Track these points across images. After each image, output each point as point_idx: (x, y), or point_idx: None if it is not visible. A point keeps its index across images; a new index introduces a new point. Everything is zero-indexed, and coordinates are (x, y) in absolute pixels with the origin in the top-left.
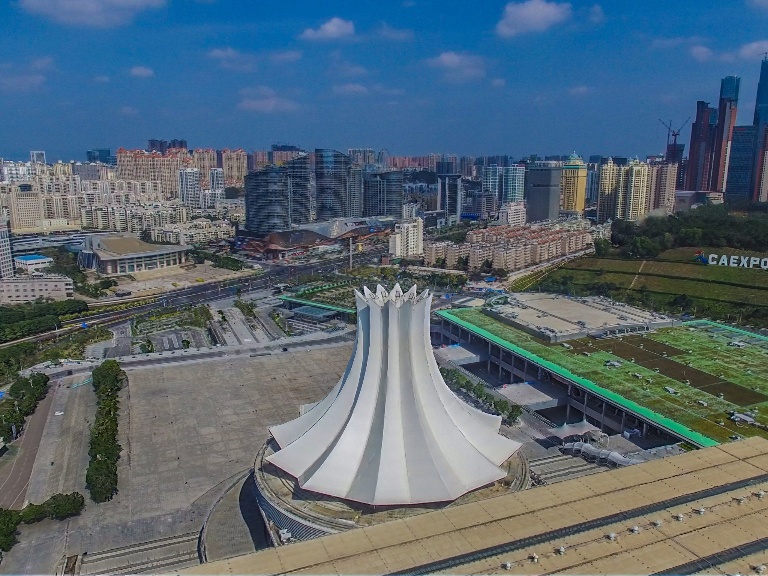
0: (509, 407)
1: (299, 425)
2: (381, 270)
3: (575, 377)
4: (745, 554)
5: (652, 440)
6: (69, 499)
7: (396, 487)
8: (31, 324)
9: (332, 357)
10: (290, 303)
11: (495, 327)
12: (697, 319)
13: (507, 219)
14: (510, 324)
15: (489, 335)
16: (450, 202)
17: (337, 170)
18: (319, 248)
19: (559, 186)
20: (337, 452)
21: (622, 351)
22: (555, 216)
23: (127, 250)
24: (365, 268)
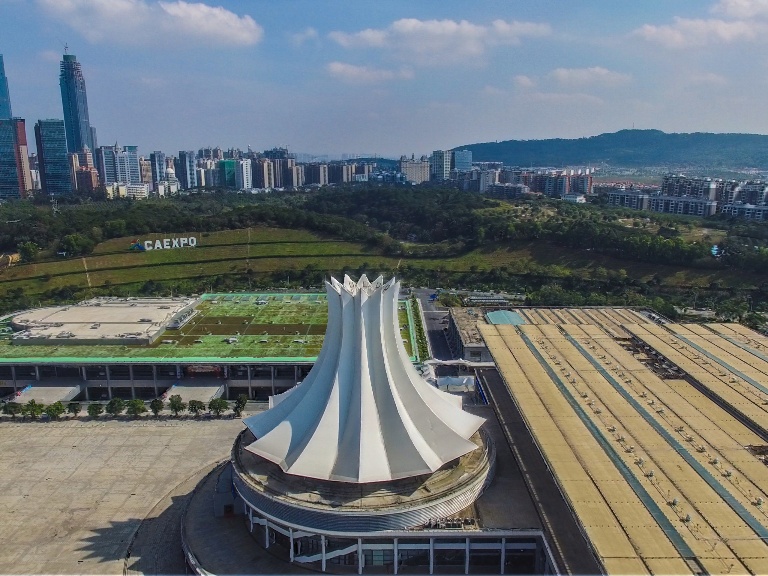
0: None
1: (317, 450)
2: None
3: (231, 359)
4: None
5: None
6: None
7: None
8: None
9: None
10: None
11: (67, 351)
12: None
13: None
14: (75, 344)
15: (79, 359)
16: None
17: None
18: None
19: None
20: None
21: (215, 330)
22: None
23: None
24: None
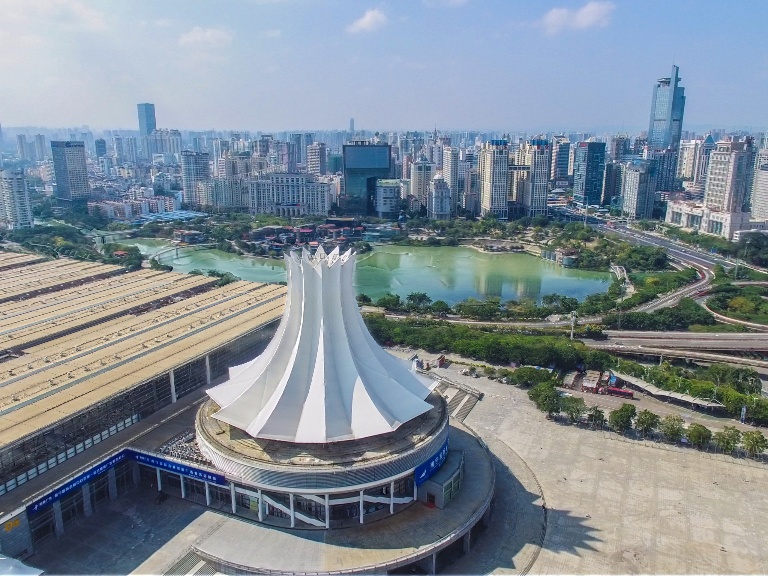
0: None
1: None
2: None
3: None
4: (33, 372)
5: None
6: None
7: None
8: None
9: None
10: None
11: None
12: None
13: None
14: None
15: None
16: None
17: None
18: None
19: None
20: None
21: None
22: None
23: None
24: None
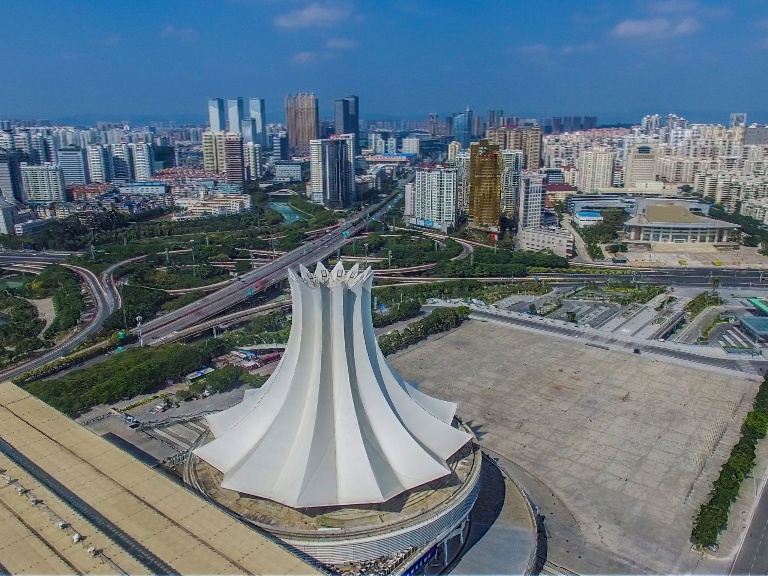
0: (759, 533)
1: None
2: None
3: None
4: None
5: None
6: None
7: (228, 453)
8: (500, 267)
9: (663, 376)
10: (760, 309)
11: None
12: None
13: None
14: None
15: None
16: None
17: None
18: None
19: None
20: (245, 404)
21: None
22: None
23: None
24: None
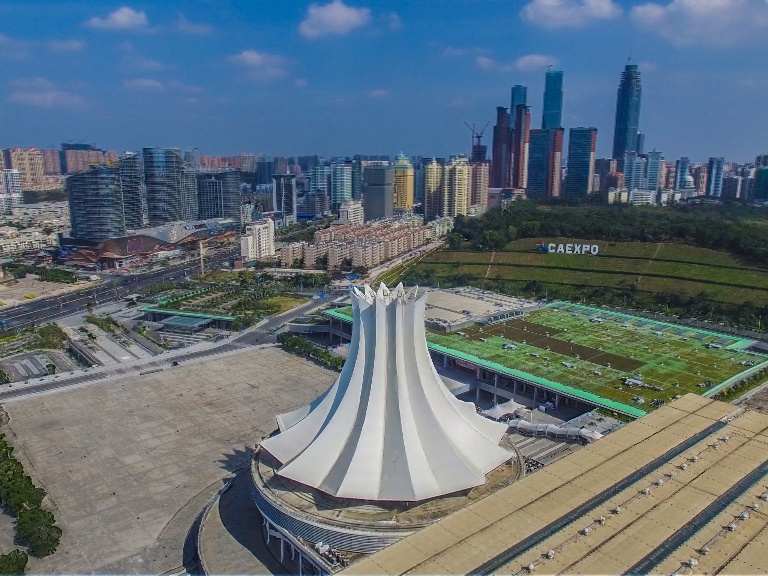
0: None
1: (294, 435)
2: (239, 274)
3: (484, 362)
4: (747, 488)
5: (564, 410)
6: (10, 559)
7: (426, 481)
8: None
9: (232, 366)
10: (154, 314)
11: None
12: (549, 301)
13: (348, 218)
14: None
15: None
16: (286, 202)
17: (169, 171)
18: (158, 254)
19: (392, 185)
20: (358, 456)
21: (511, 334)
22: (390, 214)
23: None
24: (218, 273)
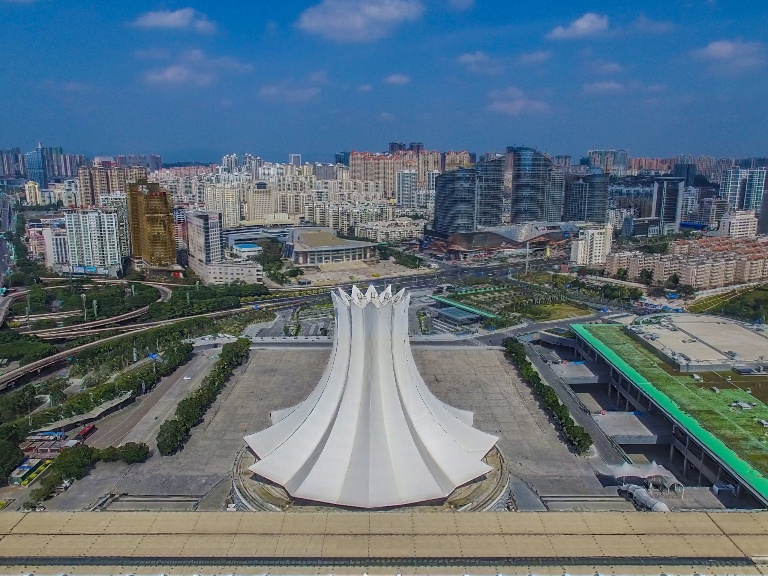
0: (593, 435)
1: None
2: (553, 277)
3: (680, 413)
4: None
5: (747, 501)
6: (136, 447)
7: (327, 485)
8: (215, 302)
9: (442, 359)
10: (441, 303)
11: (625, 347)
12: None
13: (729, 230)
14: (645, 346)
15: (612, 355)
16: (667, 208)
17: (535, 172)
18: (504, 251)
19: None
20: (292, 442)
21: (766, 392)
22: None
23: (319, 243)
24: (541, 274)
